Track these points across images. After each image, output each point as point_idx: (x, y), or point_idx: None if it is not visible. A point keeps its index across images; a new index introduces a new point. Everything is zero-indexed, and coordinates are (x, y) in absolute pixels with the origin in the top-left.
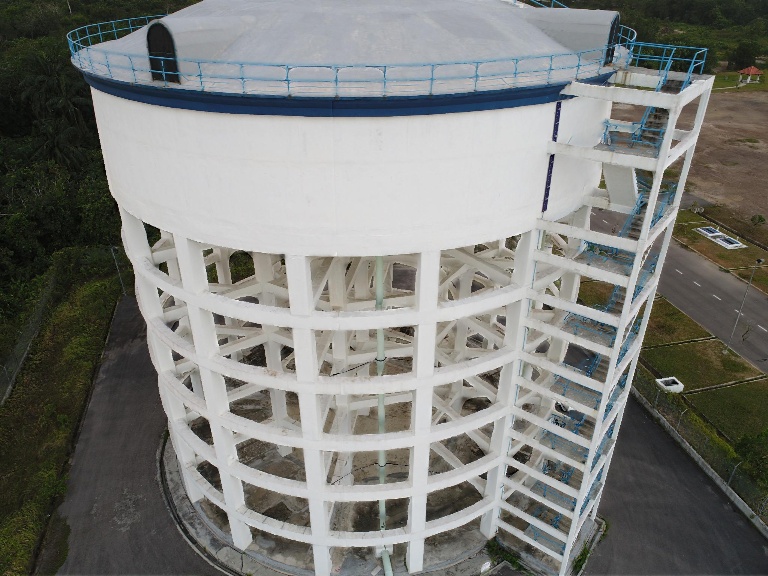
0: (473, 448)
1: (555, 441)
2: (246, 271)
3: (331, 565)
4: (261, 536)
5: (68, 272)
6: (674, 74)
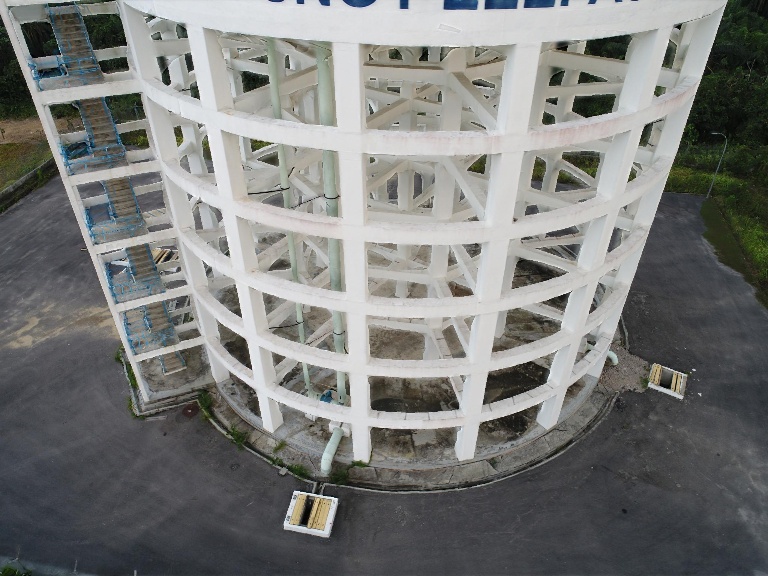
0: None
1: None
2: None
3: (257, 241)
4: None
5: (761, 168)
6: None
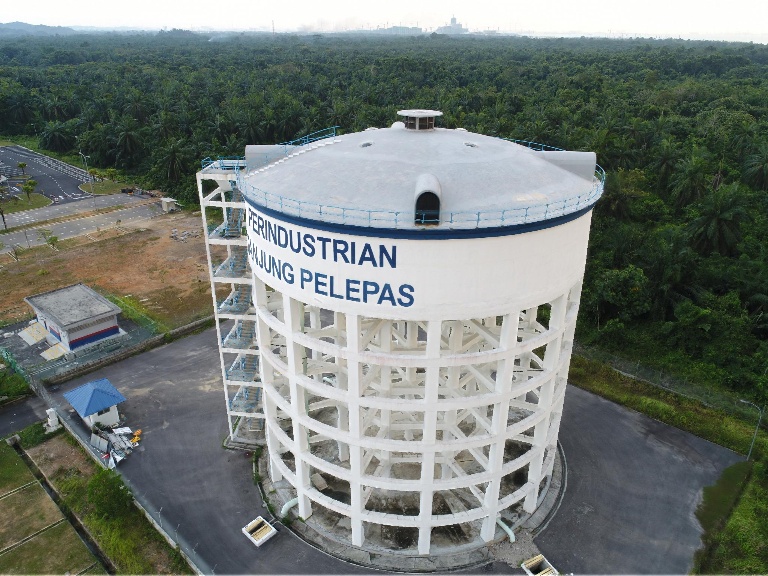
0: (321, 448)
1: (256, 340)
2: (740, 552)
3: None
4: (396, 371)
5: None
6: (216, 171)
